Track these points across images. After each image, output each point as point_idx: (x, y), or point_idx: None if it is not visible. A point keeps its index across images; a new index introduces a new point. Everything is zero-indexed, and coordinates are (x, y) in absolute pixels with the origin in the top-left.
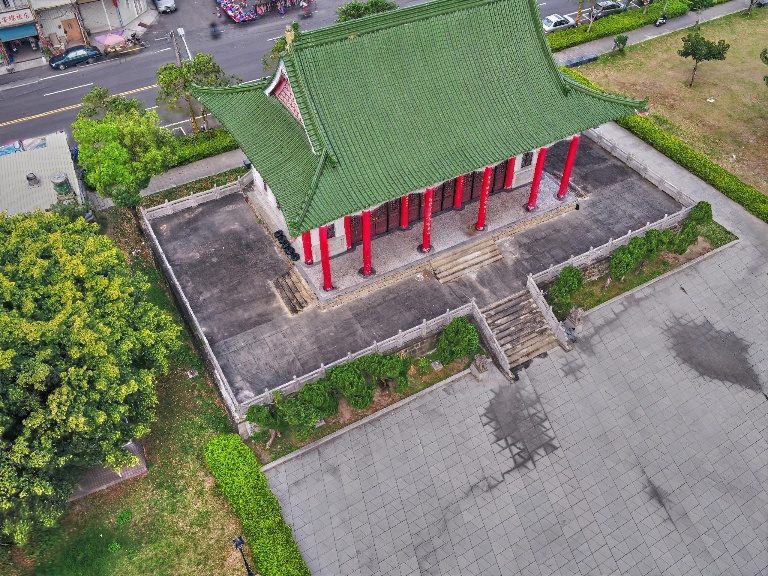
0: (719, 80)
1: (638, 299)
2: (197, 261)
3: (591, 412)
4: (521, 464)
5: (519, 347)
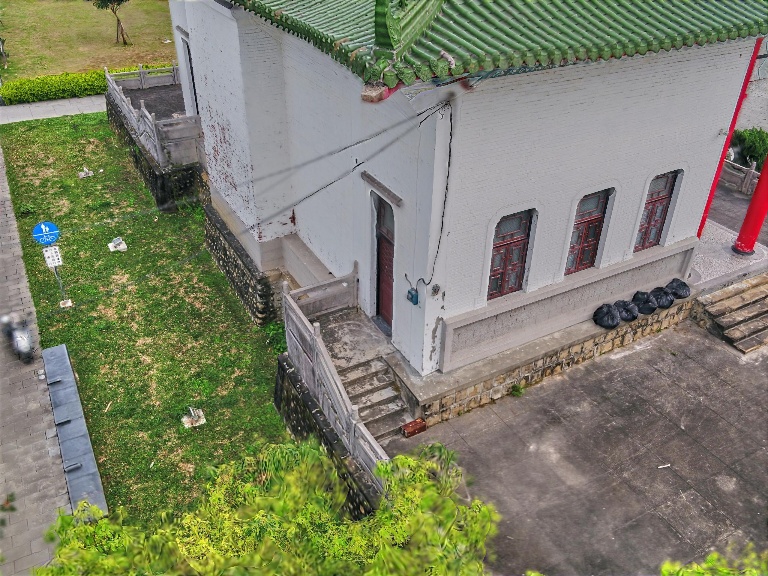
0: None
1: None
2: (760, 533)
3: None
4: None
5: None
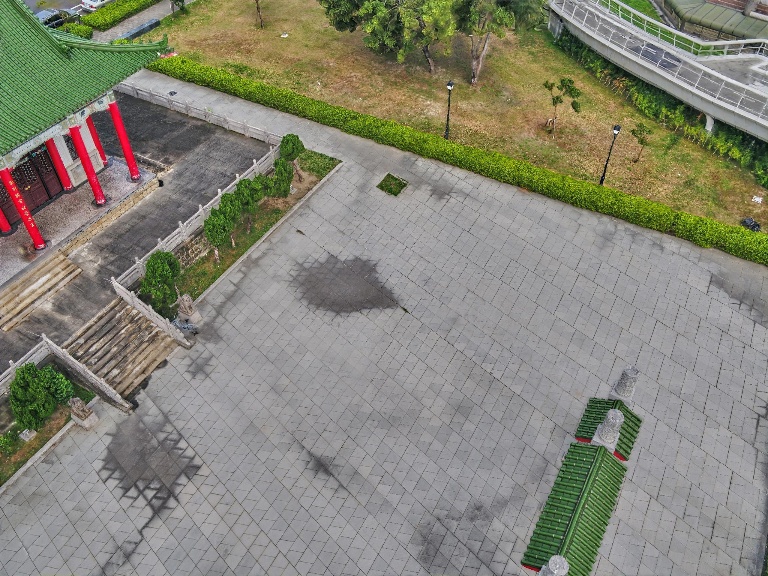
0: (288, 14)
1: (256, 259)
2: None
3: (231, 406)
4: (160, 507)
5: (129, 367)
